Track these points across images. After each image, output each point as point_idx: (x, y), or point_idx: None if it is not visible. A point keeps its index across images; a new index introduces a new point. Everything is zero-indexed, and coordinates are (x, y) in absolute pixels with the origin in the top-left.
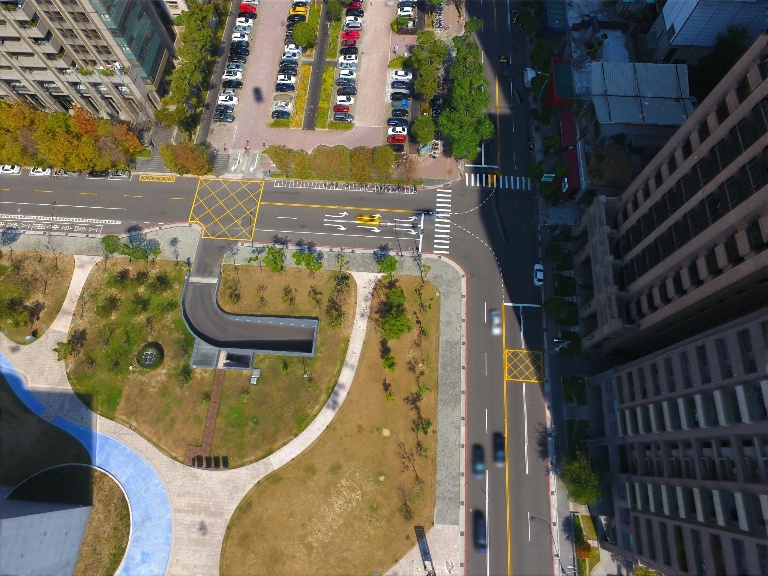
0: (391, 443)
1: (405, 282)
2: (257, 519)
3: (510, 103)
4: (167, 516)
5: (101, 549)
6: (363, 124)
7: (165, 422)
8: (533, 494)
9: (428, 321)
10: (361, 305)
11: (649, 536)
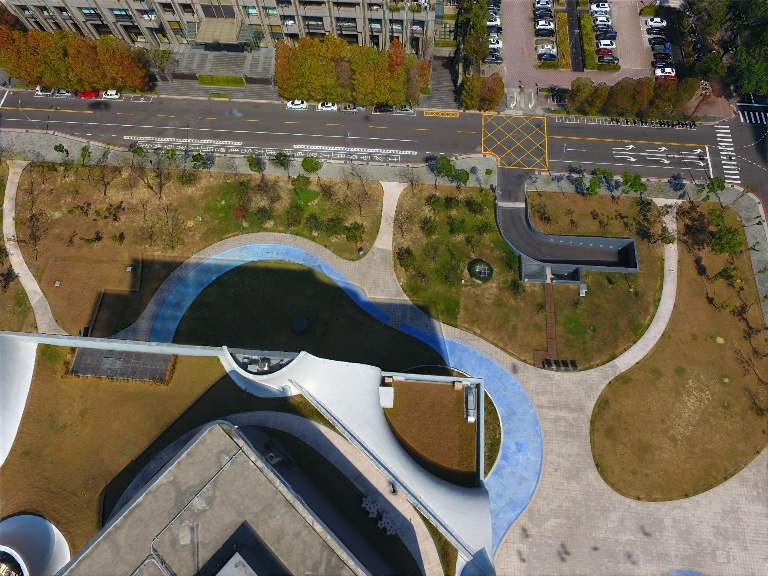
0: (727, 349)
1: (705, 208)
2: (617, 415)
3: None
4: (531, 411)
5: None
6: (628, 66)
7: (507, 329)
8: None
9: None
10: (668, 228)
11: None
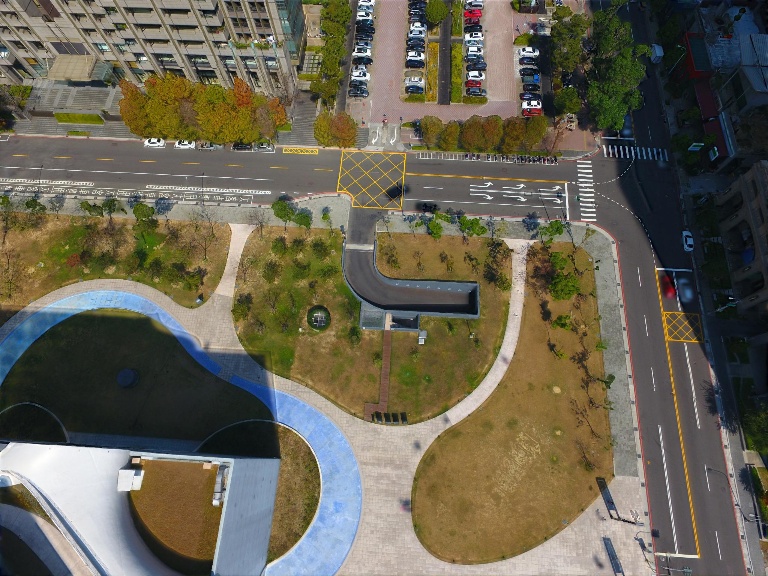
0: (563, 400)
1: (557, 248)
2: (442, 471)
3: None
4: (354, 468)
5: (295, 499)
6: (496, 99)
7: (340, 381)
8: (707, 447)
9: (584, 285)
10: (517, 270)
11: None
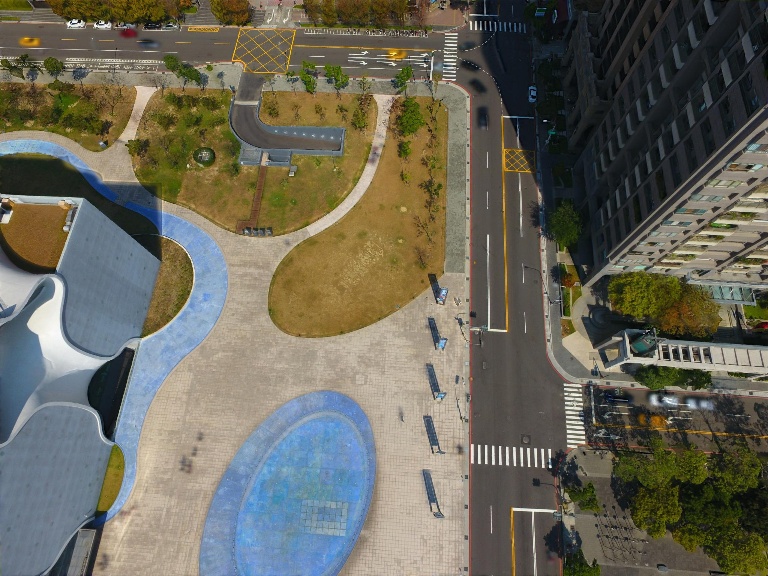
0: (408, 216)
1: (418, 101)
2: (298, 270)
3: None
4: (223, 269)
5: (170, 292)
6: None
7: (219, 204)
8: (527, 251)
9: (438, 130)
10: (381, 119)
11: (616, 229)
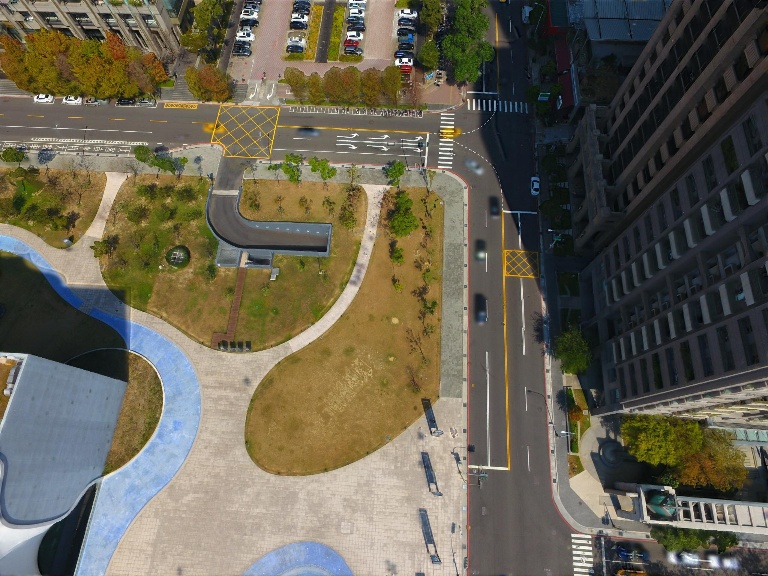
0: (400, 329)
1: (412, 193)
2: (278, 393)
3: (509, 38)
4: (196, 391)
5: (137, 419)
6: (372, 57)
7: (193, 313)
8: (530, 372)
9: (433, 226)
10: (371, 213)
11: (632, 378)
